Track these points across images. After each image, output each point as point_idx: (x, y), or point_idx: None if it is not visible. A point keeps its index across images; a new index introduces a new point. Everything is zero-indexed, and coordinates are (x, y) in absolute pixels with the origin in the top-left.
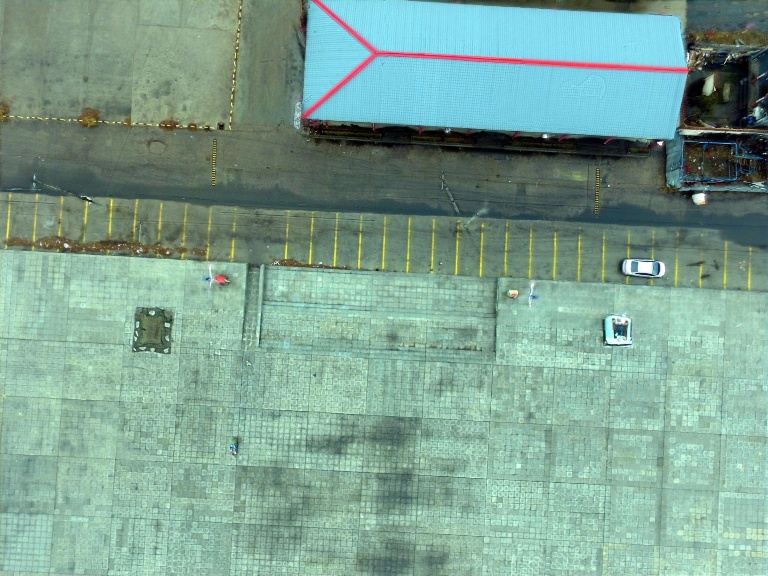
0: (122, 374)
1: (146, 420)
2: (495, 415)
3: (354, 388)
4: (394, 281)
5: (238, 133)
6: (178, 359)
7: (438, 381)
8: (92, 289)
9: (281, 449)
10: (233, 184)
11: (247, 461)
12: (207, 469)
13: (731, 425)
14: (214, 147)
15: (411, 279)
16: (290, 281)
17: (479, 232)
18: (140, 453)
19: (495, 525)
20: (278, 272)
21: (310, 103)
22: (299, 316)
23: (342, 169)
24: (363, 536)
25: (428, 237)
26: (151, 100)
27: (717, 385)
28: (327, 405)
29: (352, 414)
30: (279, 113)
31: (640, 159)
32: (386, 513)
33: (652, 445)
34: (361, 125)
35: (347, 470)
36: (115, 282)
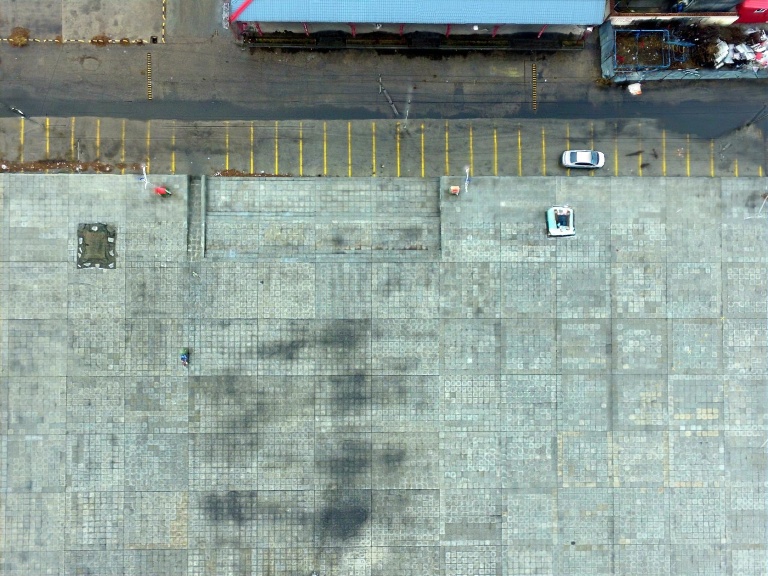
0: (68, 291)
1: (95, 336)
2: (444, 312)
3: (302, 293)
4: (337, 185)
5: (172, 46)
6: (124, 273)
7: (385, 281)
8: (32, 208)
9: (233, 357)
10: (170, 97)
11: (199, 371)
12: (159, 381)
13: (676, 309)
14: (148, 61)
15: (354, 183)
16: (233, 191)
17: (419, 133)
18: (91, 369)
19: (449, 420)
20: (220, 182)
21: (238, 4)
22: (243, 225)
23: (279, 77)
24: (319, 438)
25: (369, 140)
26: (82, 16)
27: (661, 270)
28: (276, 311)
29: (302, 319)
30: (212, 24)
31: (575, 52)
32: (341, 414)
33: (600, 333)
34: (295, 31)
35: (300, 374)
36: (55, 200)
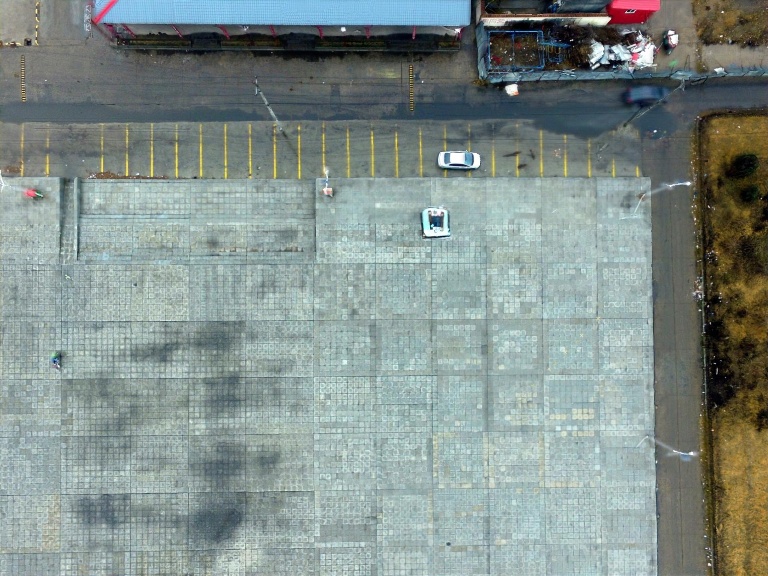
0: None
1: None
2: (319, 313)
3: (176, 295)
4: (212, 188)
5: (46, 48)
6: None
7: (260, 283)
8: None
9: (106, 360)
10: (44, 100)
11: (72, 374)
12: (32, 384)
13: (552, 309)
14: (22, 63)
15: (229, 185)
16: (107, 193)
17: (296, 135)
18: None
19: (324, 422)
20: (94, 185)
21: (102, 6)
22: (117, 227)
23: (154, 79)
24: (193, 441)
25: (245, 142)
26: None
27: (536, 271)
28: (150, 314)
29: (175, 321)
30: None
31: (452, 53)
32: (215, 417)
33: (476, 334)
34: (169, 33)
35: (173, 377)
36: None
